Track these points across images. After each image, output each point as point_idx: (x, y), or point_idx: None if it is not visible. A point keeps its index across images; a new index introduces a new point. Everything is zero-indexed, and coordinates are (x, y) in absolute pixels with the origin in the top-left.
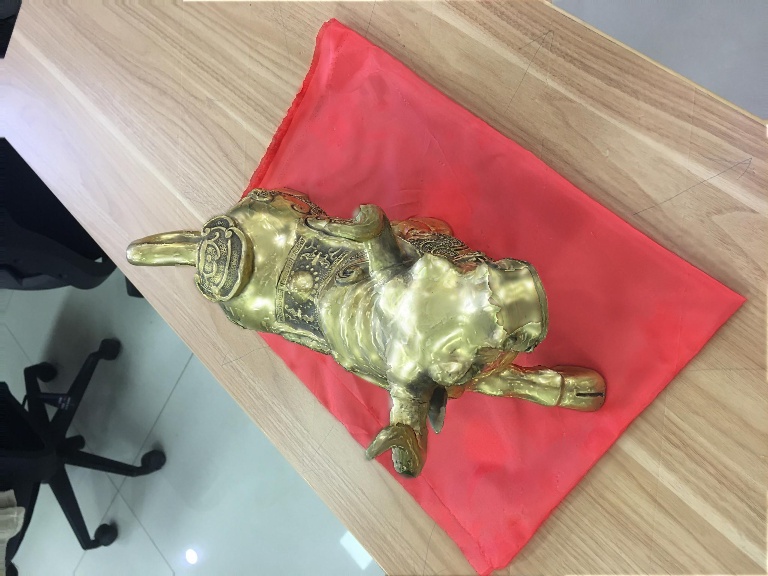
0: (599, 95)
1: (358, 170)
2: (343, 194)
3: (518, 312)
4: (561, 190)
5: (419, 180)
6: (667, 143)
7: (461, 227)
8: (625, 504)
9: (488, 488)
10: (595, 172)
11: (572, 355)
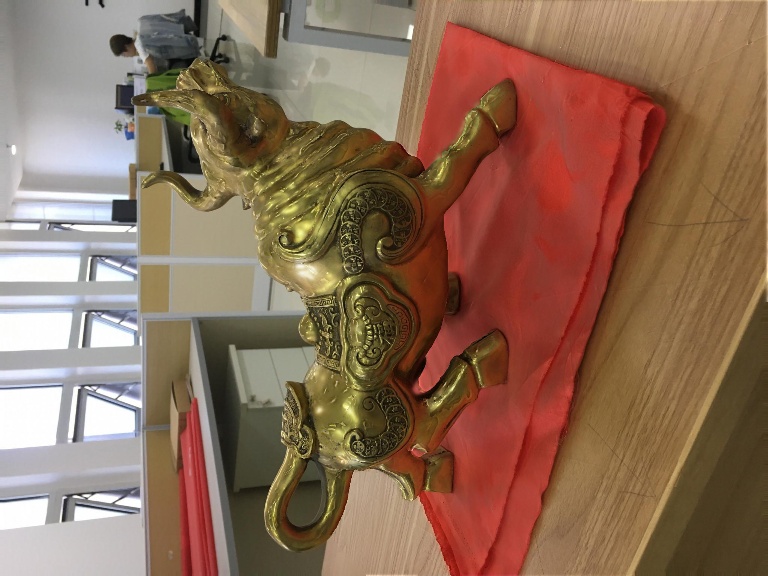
0: None
1: (427, 383)
2: None
3: None
4: None
5: None
6: None
7: None
8: (567, 5)
9: (567, 153)
10: None
11: None
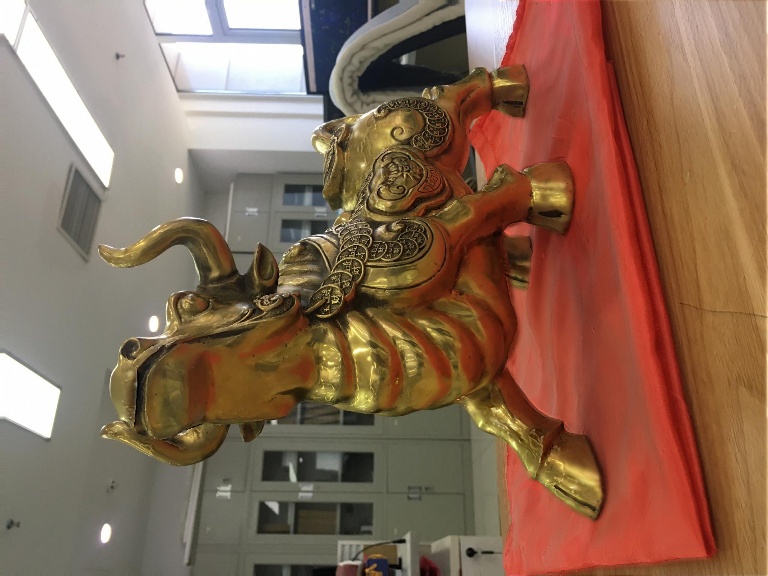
0: (708, 60)
1: (551, 70)
2: (539, 96)
3: (212, 393)
4: (614, 213)
5: (572, 110)
6: (741, 206)
7: (579, 198)
8: None
9: (523, 501)
10: (670, 202)
11: (597, 437)
